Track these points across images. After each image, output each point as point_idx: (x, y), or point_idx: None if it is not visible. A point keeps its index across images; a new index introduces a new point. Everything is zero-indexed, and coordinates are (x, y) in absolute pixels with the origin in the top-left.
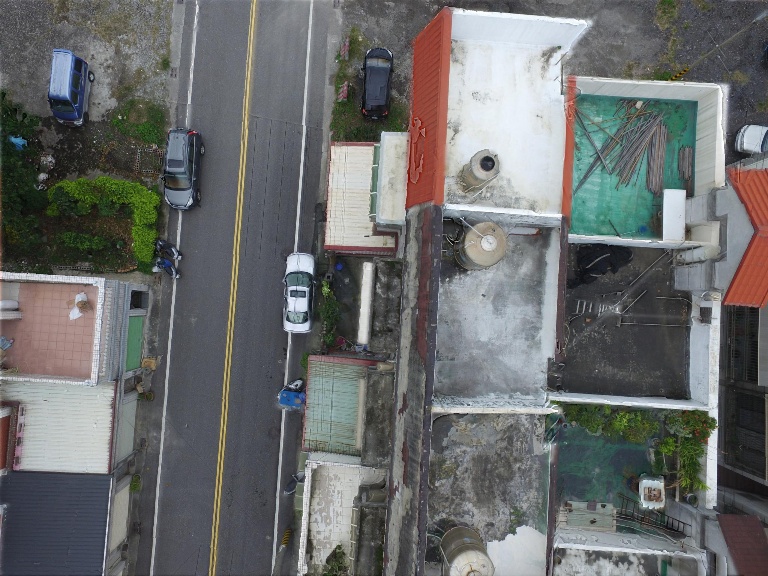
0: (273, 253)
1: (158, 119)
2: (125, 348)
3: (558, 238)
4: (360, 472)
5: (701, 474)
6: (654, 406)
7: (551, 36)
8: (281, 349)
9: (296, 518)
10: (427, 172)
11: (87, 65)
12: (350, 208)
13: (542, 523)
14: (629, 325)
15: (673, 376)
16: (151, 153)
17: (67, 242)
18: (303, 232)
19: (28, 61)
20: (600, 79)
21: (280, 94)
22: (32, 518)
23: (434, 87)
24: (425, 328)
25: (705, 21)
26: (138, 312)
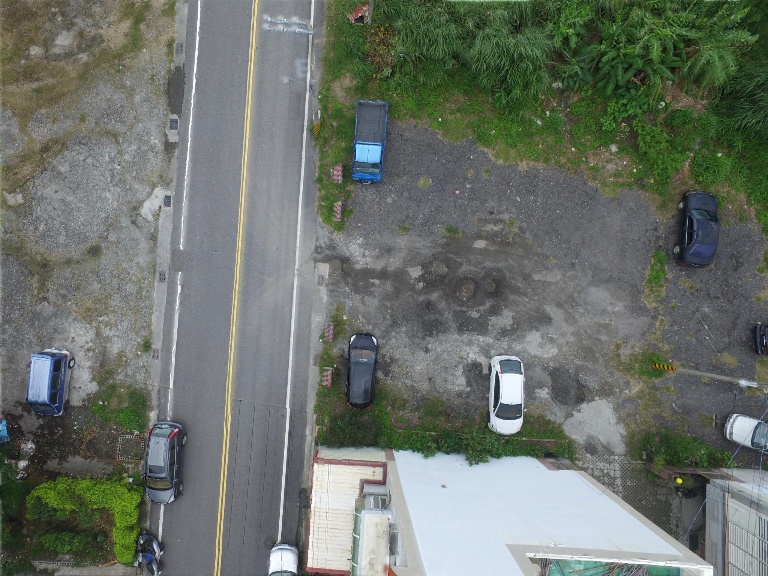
0: (257, 541)
1: (140, 405)
2: None
3: None
4: None
5: None
6: None
7: None
8: None
9: None
10: None
11: (67, 357)
12: (333, 529)
13: None
14: None
15: None
16: (133, 440)
17: (46, 547)
18: (287, 518)
19: (7, 345)
20: (580, 557)
21: (263, 376)
22: None
23: None
24: None
25: (693, 301)
26: None
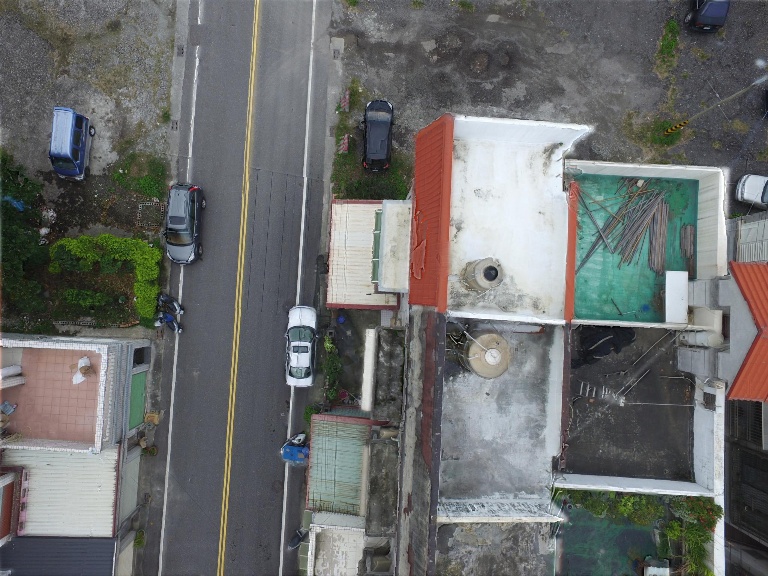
0: (275, 306)
1: (159, 173)
2: (128, 406)
3: (561, 335)
4: (364, 532)
5: (706, 560)
6: (659, 492)
7: (553, 135)
8: (284, 402)
9: (300, 572)
10: (430, 263)
11: (88, 120)
12: (352, 266)
13: None
14: (632, 405)
15: (677, 456)
16: (152, 207)
17: (69, 299)
18: (305, 284)
19: (29, 115)
20: (601, 163)
21: (281, 146)
22: None
23: (436, 187)
24: (430, 435)
25: (704, 70)
26: (141, 369)
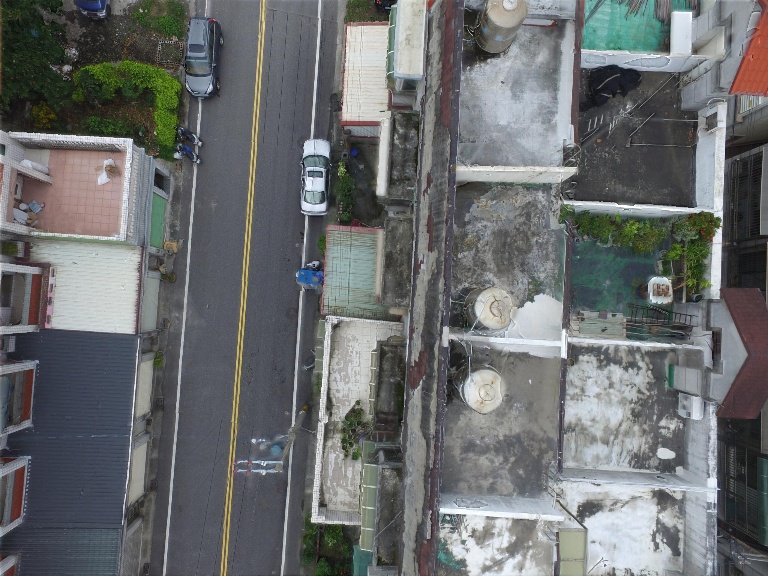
0: (290, 141)
1: (178, 12)
2: (149, 224)
3: (572, 30)
4: (377, 334)
5: (707, 273)
6: (662, 209)
7: None
8: (298, 233)
9: (314, 395)
10: None
11: None
12: (366, 85)
13: (558, 292)
14: (638, 146)
15: (680, 193)
16: (171, 45)
17: (92, 126)
18: (319, 121)
19: None
20: None
21: None
22: (63, 374)
23: None
24: (449, 98)
25: None
26: (161, 192)
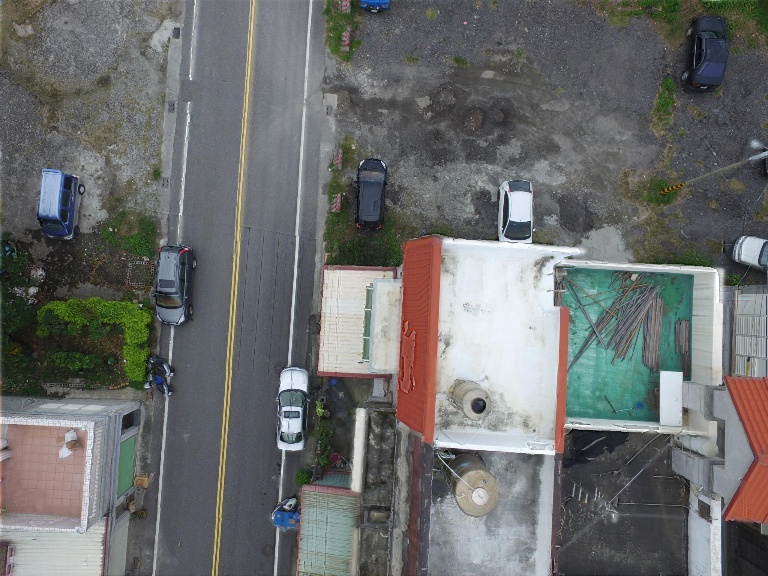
0: (266, 366)
1: (149, 231)
2: (116, 474)
3: None
4: None
5: None
6: None
7: None
8: (275, 464)
9: None
10: (418, 372)
11: (77, 180)
12: (343, 334)
13: None
14: (626, 505)
15: (671, 557)
16: (142, 266)
17: (57, 363)
18: (297, 344)
19: (18, 173)
20: (594, 263)
21: (273, 204)
22: None
23: (424, 305)
24: (416, 567)
25: (701, 128)
26: (130, 434)
